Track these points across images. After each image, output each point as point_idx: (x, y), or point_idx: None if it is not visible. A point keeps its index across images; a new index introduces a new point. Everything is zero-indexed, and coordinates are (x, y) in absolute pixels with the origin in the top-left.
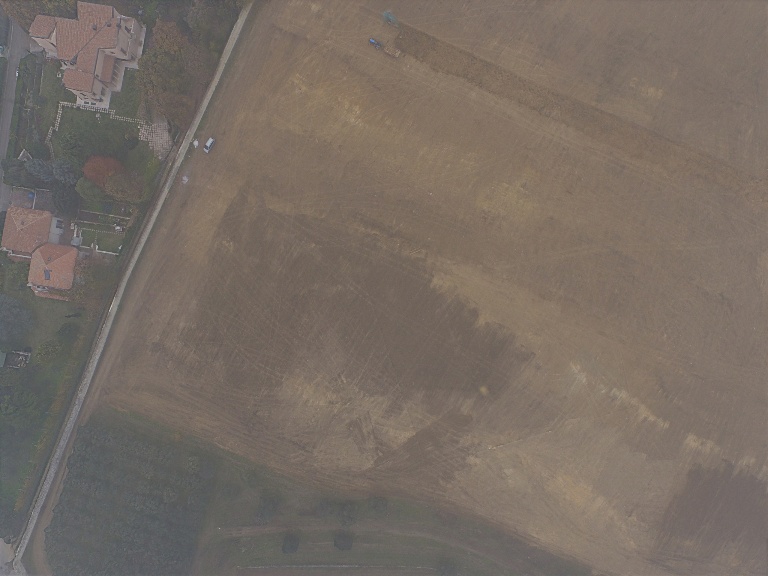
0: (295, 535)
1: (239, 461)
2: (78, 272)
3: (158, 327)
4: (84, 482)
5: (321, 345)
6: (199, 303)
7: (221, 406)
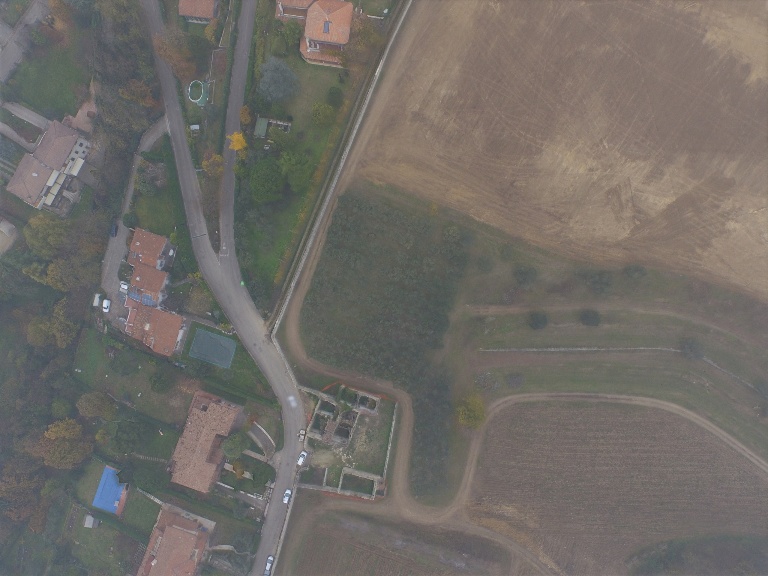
0: (540, 314)
1: (492, 235)
2: (357, 24)
3: (418, 95)
4: (345, 251)
5: (584, 110)
6: (462, 69)
7: (478, 177)
